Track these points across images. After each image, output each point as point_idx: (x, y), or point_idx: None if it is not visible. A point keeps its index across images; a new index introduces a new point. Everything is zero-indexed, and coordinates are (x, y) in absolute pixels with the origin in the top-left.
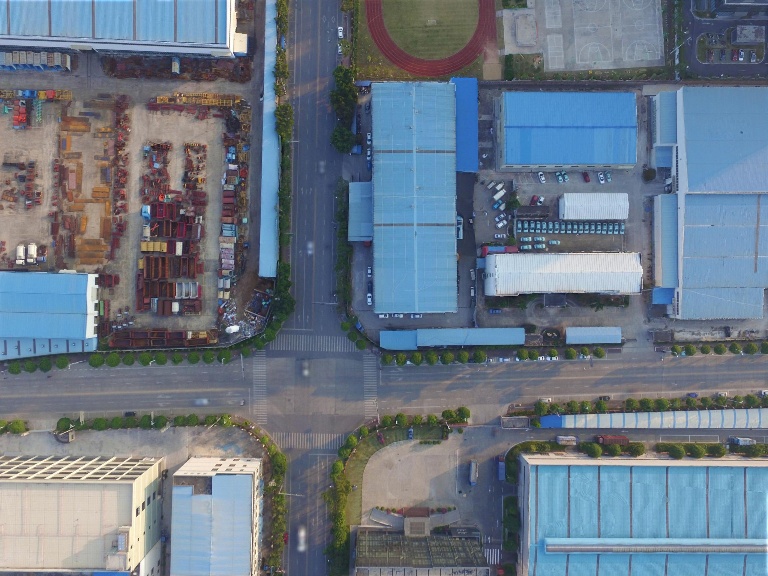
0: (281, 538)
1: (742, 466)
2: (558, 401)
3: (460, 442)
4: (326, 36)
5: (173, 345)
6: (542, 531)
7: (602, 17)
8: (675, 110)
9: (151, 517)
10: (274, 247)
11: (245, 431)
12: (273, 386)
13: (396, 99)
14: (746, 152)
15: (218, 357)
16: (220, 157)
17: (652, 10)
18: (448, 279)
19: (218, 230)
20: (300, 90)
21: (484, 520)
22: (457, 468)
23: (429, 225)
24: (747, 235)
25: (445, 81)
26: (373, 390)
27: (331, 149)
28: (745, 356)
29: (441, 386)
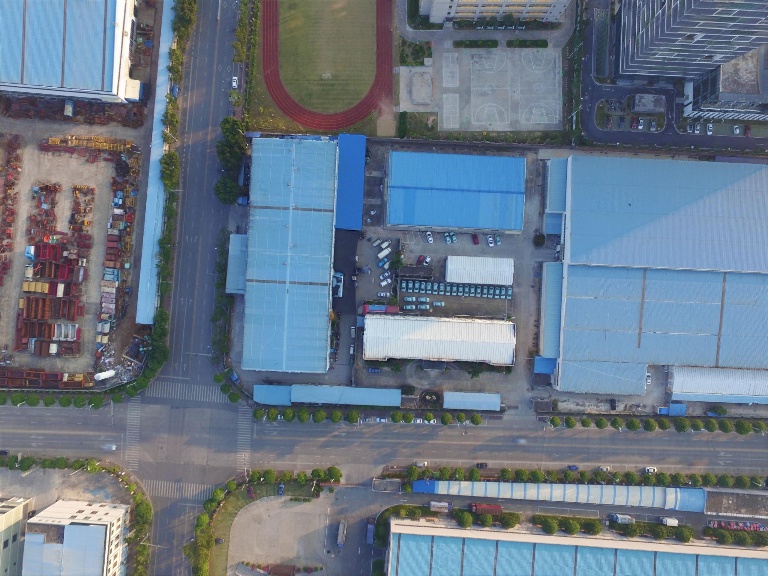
0: None
1: (612, 548)
2: (434, 465)
3: (332, 501)
4: (221, 85)
5: (48, 386)
6: None
7: (500, 78)
8: (565, 177)
9: (9, 560)
10: (153, 294)
11: (115, 477)
12: (146, 433)
13: (276, 155)
14: (633, 225)
15: (88, 402)
16: (108, 201)
17: (552, 73)
18: (318, 339)
19: (101, 273)
20: (191, 138)
21: None
22: (327, 527)
23: (302, 283)
24: (631, 309)
25: (335, 136)
26: (247, 443)
27: (217, 199)
28: (630, 431)
29: (316, 443)
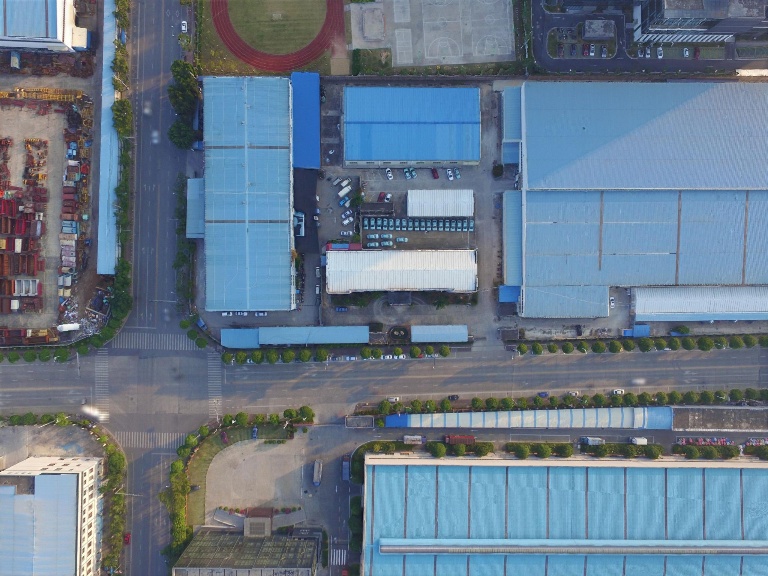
0: (119, 538)
1: (582, 466)
2: (406, 400)
3: (306, 441)
4: (170, 30)
5: (12, 343)
6: (378, 532)
7: (452, 11)
8: (520, 106)
9: None
10: (113, 244)
11: (86, 430)
12: (115, 385)
13: (228, 94)
14: (588, 148)
15: (53, 355)
16: (62, 153)
17: (503, 4)
18: (281, 277)
19: (59, 227)
20: (143, 85)
21: (330, 520)
22: (302, 468)
23: (261, 222)
24: (590, 232)
25: (289, 76)
26: (218, 389)
27: (173, 145)
28: (597, 355)
29: (287, 385)
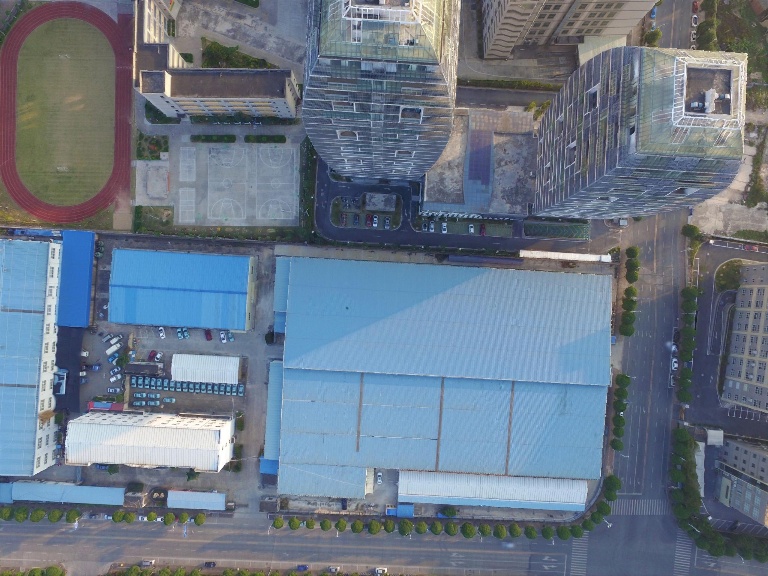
0: None
1: None
2: (163, 563)
3: None
4: None
5: None
6: None
7: (238, 173)
8: None
9: None
10: None
11: None
12: None
13: None
14: (349, 329)
15: None
16: None
17: (290, 169)
18: (25, 442)
19: None
20: None
21: None
22: None
23: (9, 385)
24: (349, 413)
25: None
26: None
27: None
28: None
29: (43, 539)
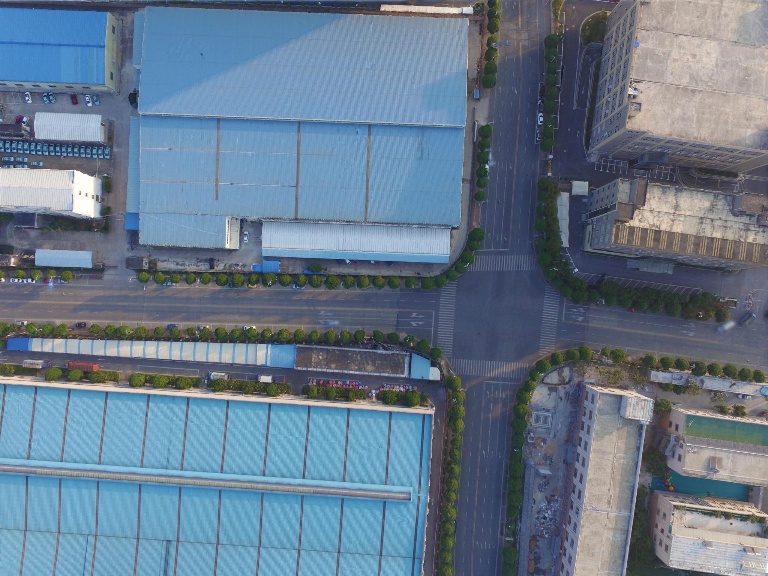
0: None
1: (181, 396)
2: None
3: None
4: None
5: None
6: None
7: None
8: None
9: None
10: None
11: None
12: None
13: None
14: (204, 74)
15: None
16: None
17: None
18: None
19: None
20: None
21: None
22: None
23: None
24: (207, 160)
25: None
26: None
27: None
28: (230, 290)
29: None
